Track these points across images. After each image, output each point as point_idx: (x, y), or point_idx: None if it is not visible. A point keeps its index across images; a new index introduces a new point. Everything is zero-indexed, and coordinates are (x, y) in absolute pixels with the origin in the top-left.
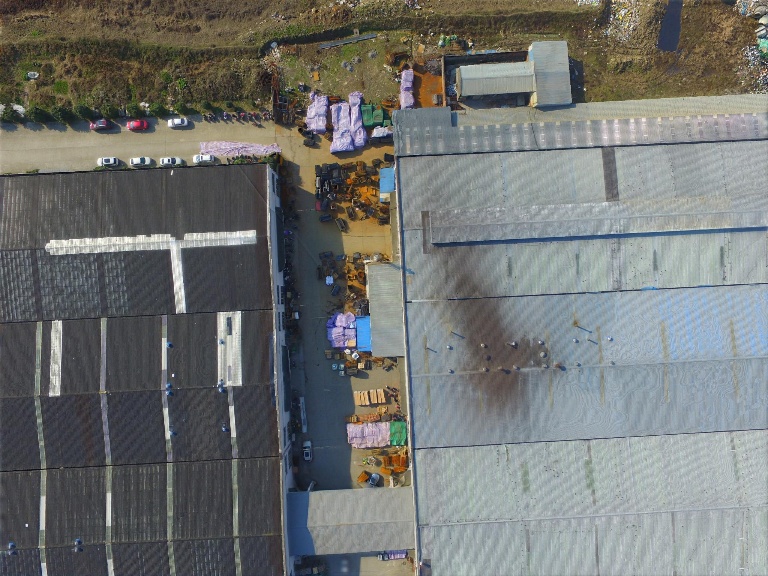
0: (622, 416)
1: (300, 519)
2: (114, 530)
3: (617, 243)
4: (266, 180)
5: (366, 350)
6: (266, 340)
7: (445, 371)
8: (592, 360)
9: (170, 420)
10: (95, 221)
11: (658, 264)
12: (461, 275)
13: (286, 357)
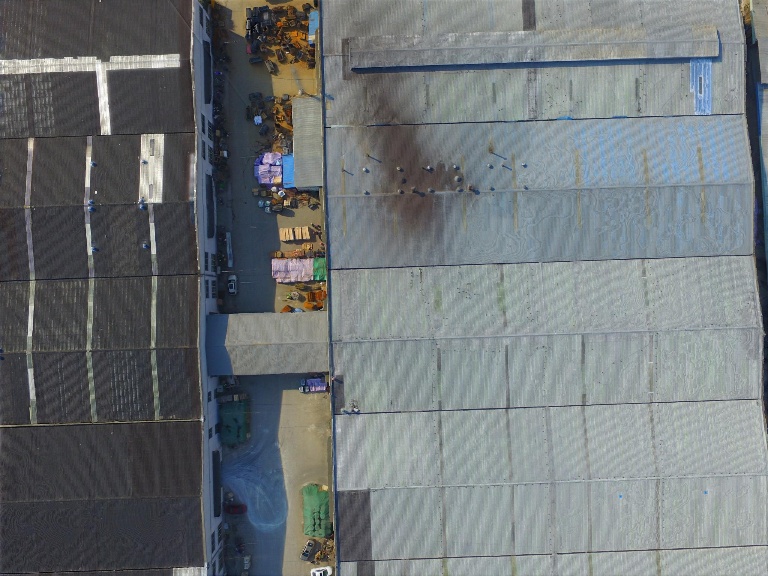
0: (536, 244)
1: (218, 338)
2: (35, 340)
3: (533, 73)
4: (191, 8)
5: (291, 186)
6: (187, 161)
7: (361, 192)
8: (506, 185)
9: (92, 236)
10: (24, 44)
11: (574, 95)
12: (379, 102)
13: (210, 186)
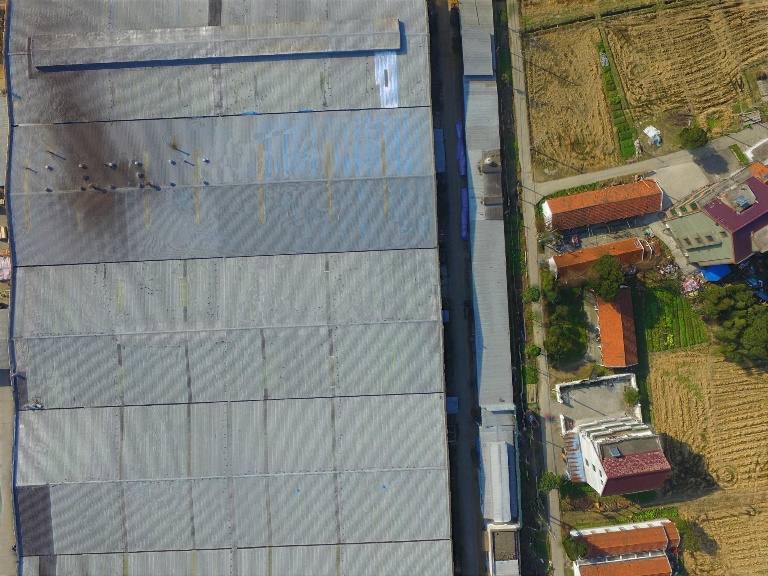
0: (224, 239)
1: None
2: None
3: (217, 68)
4: None
5: None
6: None
7: (43, 190)
8: (187, 181)
9: None
10: None
11: (259, 89)
12: (65, 99)
13: None
